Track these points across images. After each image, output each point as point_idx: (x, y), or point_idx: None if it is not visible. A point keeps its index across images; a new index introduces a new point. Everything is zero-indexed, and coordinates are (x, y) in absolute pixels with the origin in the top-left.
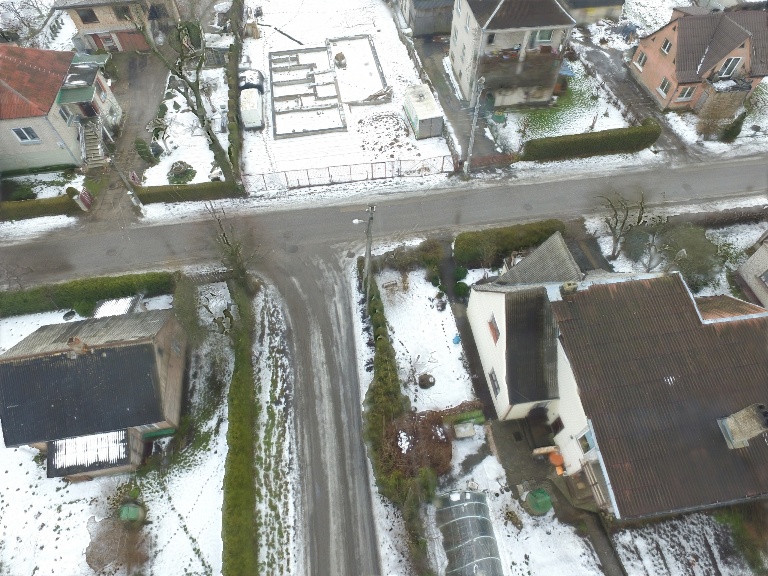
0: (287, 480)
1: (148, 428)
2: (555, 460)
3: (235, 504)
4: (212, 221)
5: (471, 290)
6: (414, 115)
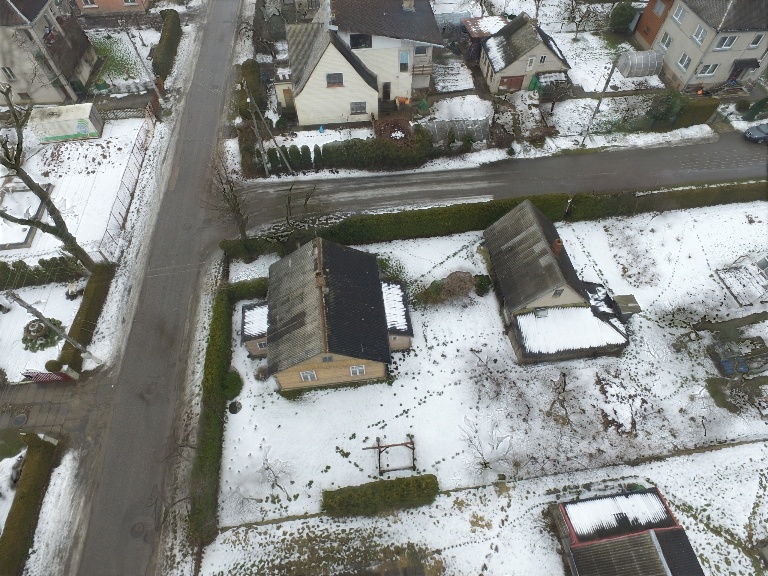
0: None
1: None
2: (403, 100)
3: None
4: (142, 291)
5: (295, 101)
6: (74, 125)
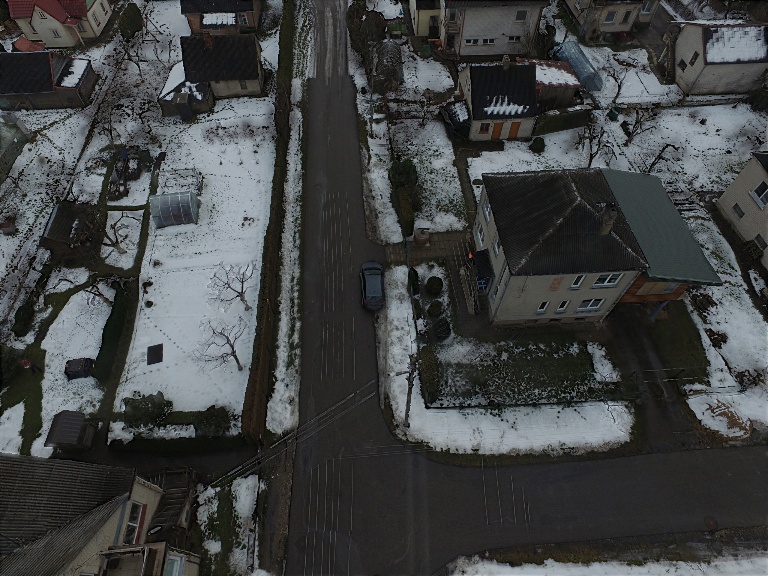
0: (308, 45)
1: (243, 24)
2: (438, 43)
3: (285, 30)
4: None
5: None
6: None
